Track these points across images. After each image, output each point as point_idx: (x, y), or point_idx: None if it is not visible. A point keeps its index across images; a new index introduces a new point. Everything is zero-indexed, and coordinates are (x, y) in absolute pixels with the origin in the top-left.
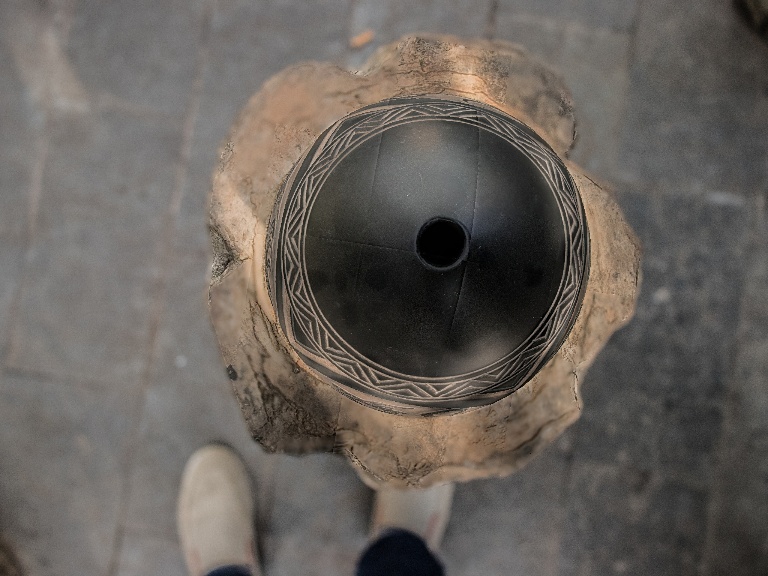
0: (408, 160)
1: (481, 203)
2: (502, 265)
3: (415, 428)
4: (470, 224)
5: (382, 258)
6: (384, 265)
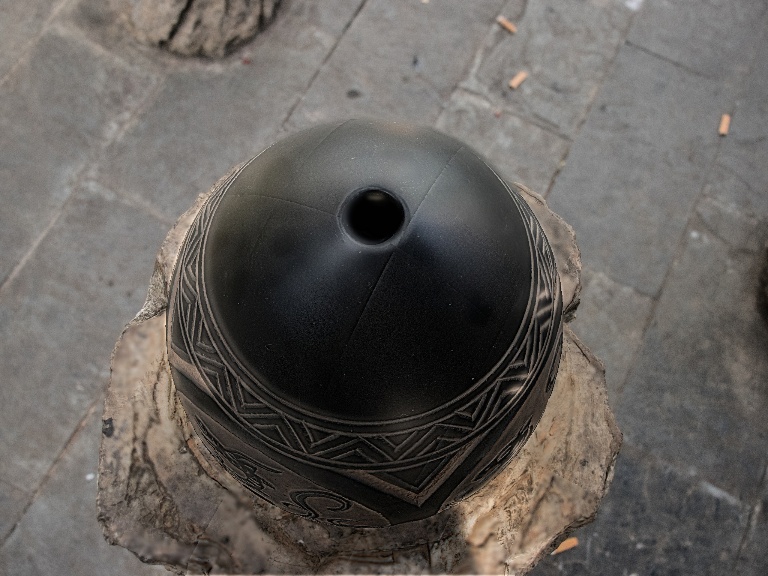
0: (368, 134)
1: (436, 193)
2: (440, 274)
3: (295, 569)
4: (415, 206)
5: (295, 217)
6: (294, 226)
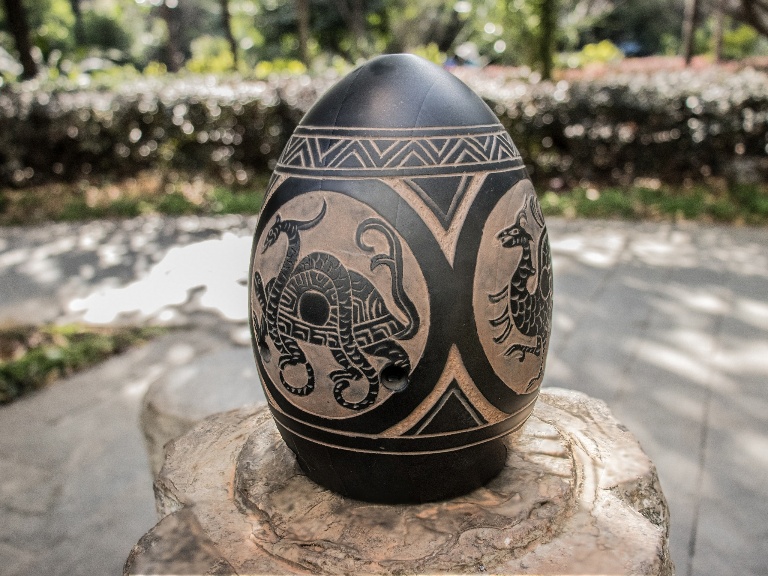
0: (402, 84)
1: (361, 66)
2: None
3: None
4: None
5: None
6: None
